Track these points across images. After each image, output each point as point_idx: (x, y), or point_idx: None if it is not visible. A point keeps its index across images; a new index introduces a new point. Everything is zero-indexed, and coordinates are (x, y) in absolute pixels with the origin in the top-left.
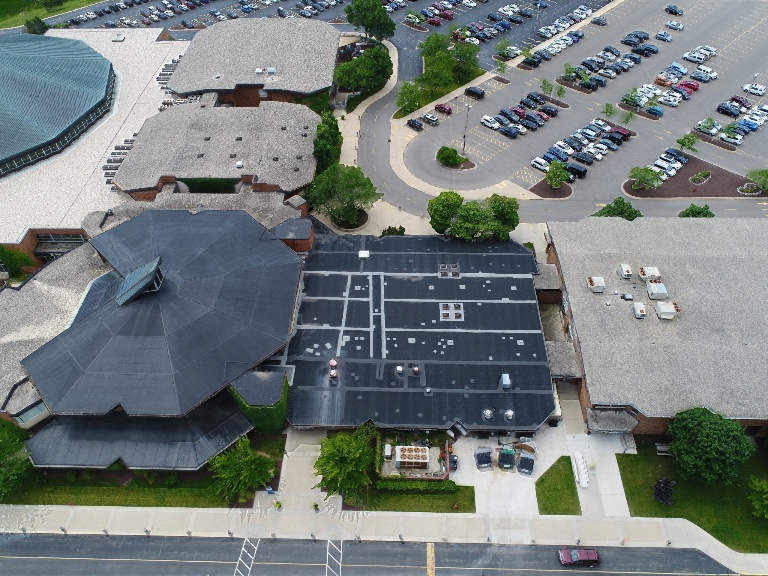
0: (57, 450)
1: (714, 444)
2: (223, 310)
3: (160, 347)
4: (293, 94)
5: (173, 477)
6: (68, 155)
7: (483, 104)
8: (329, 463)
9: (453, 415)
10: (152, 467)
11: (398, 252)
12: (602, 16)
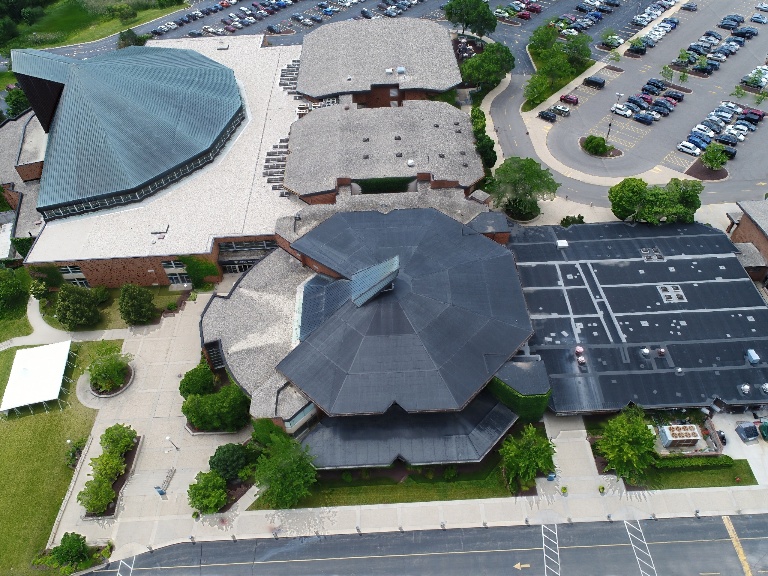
0: (334, 452)
1: None
2: (461, 305)
3: (415, 344)
4: (427, 92)
5: (452, 471)
6: (221, 164)
7: (606, 93)
8: (623, 445)
9: (710, 392)
10: (434, 462)
11: (592, 240)
12: (691, 2)
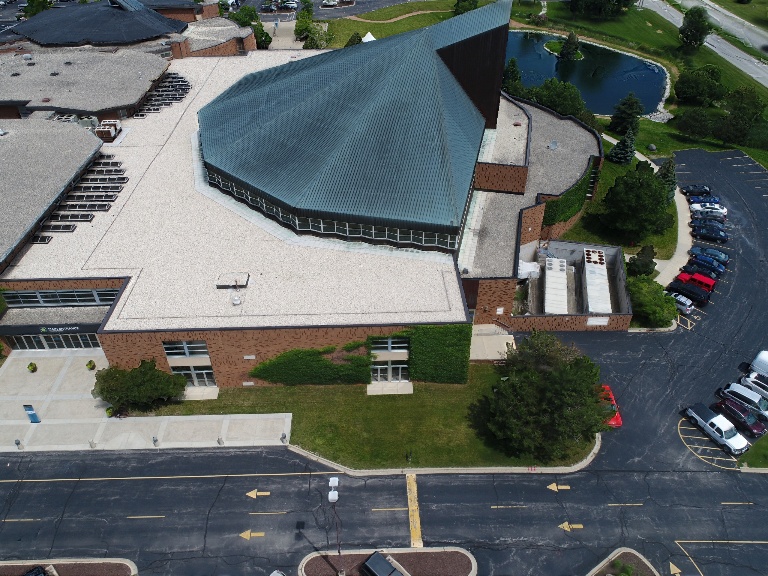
0: None
1: None
2: None
3: None
4: None
5: None
6: None
7: None
8: None
9: None
10: None
11: None
12: None
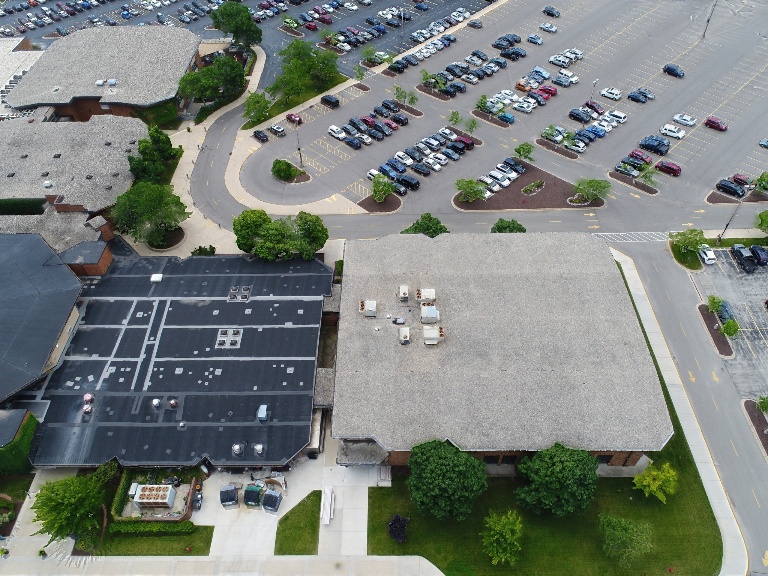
0: None
1: (437, 481)
2: None
3: None
4: (132, 106)
5: None
6: None
7: (336, 113)
8: (45, 509)
9: (203, 450)
10: None
11: (195, 274)
12: (478, 19)
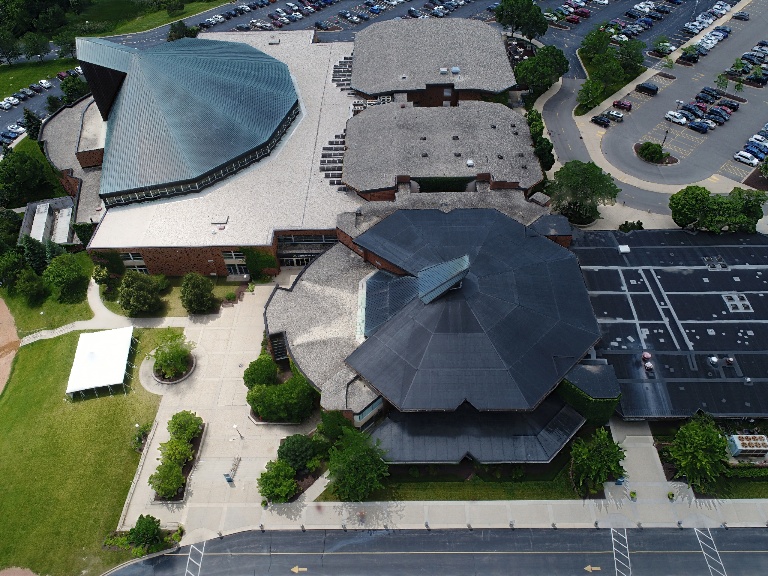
0: (402, 447)
1: None
2: (529, 306)
3: (484, 343)
4: (481, 93)
5: (520, 471)
6: (278, 157)
7: (659, 100)
8: (696, 452)
9: None
10: (503, 461)
11: (654, 246)
12: (743, 11)
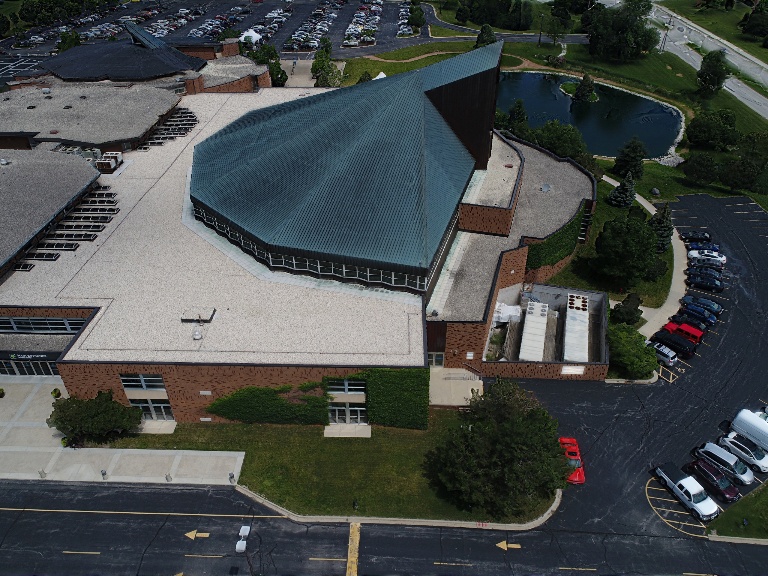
0: None
1: None
2: None
3: None
4: None
5: None
6: None
7: None
8: None
9: None
10: None
11: None
12: None
